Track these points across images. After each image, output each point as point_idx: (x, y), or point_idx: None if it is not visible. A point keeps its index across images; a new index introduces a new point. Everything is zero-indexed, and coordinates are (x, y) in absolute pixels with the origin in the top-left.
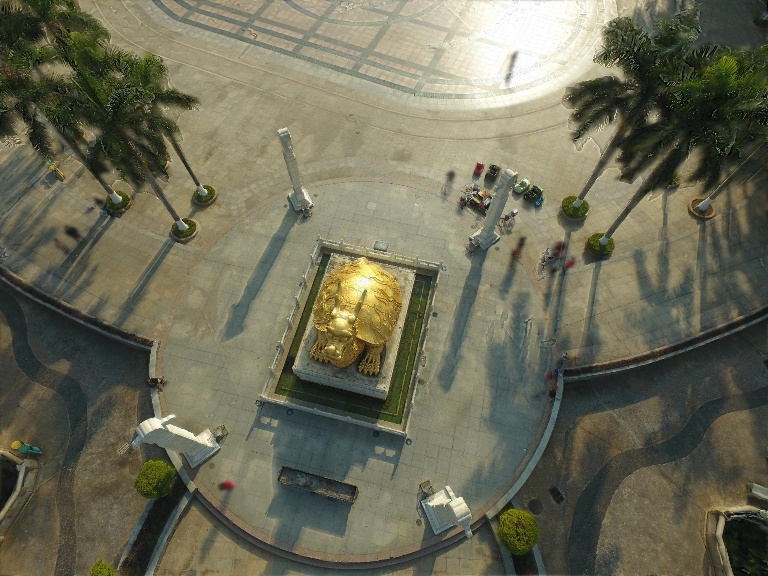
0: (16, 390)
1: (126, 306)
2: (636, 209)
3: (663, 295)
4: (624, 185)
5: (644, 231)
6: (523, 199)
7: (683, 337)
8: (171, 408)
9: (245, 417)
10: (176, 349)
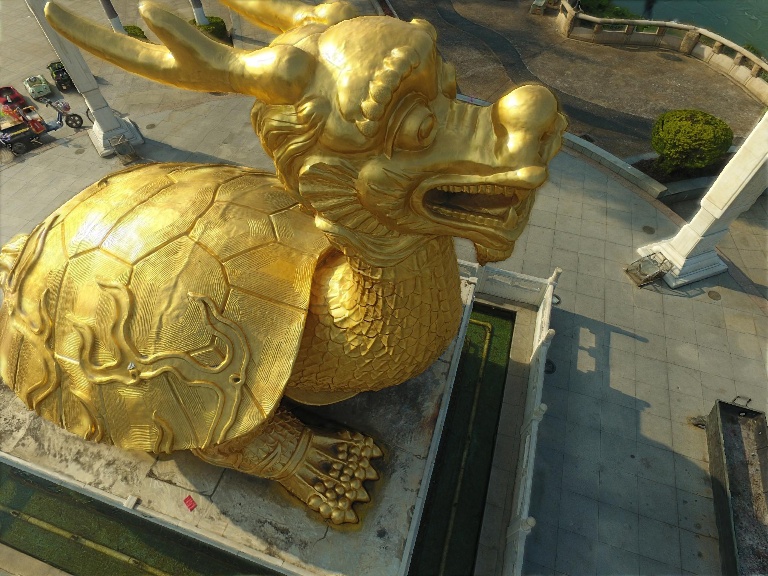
0: None
1: None
2: (165, 5)
3: (306, 2)
4: (119, 6)
5: (204, 5)
6: (66, 93)
7: (366, 1)
8: None
9: None
10: None
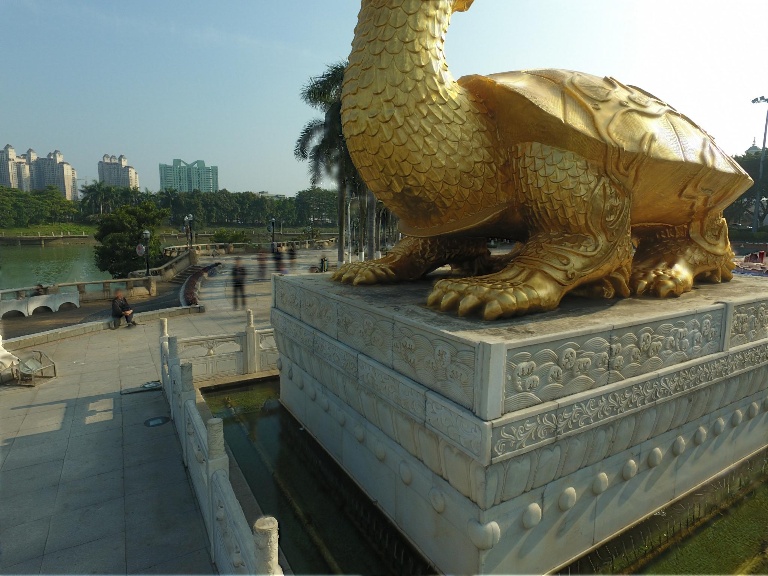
0: (66, 316)
1: (232, 296)
2: None
3: None
4: None
5: None
6: None
7: None
8: (79, 340)
9: (97, 385)
10: (203, 318)
